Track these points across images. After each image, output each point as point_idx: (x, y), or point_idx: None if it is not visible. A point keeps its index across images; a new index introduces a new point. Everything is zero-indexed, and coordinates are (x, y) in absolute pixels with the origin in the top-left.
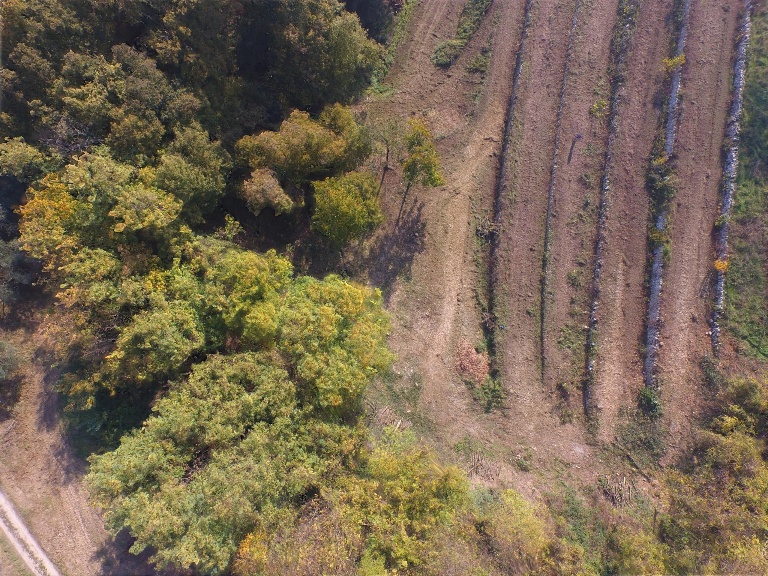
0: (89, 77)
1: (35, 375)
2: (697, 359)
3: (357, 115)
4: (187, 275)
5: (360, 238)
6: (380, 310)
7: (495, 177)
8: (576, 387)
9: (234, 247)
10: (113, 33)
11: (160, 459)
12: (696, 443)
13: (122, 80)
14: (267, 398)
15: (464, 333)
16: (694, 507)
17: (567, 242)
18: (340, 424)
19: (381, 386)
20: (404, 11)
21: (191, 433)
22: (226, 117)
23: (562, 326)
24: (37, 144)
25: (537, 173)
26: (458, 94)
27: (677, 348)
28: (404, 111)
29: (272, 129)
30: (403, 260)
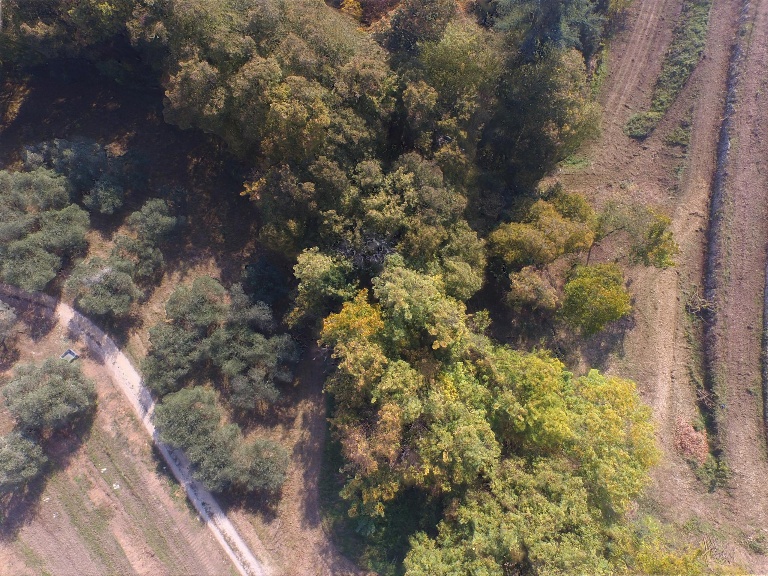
0: (378, 185)
1: (294, 471)
2: None
3: (552, 187)
4: (471, 379)
5: None
6: None
7: (702, 252)
8: None
9: (493, 342)
10: (387, 136)
11: None
12: None
13: (411, 188)
14: (572, 508)
15: (680, 410)
16: None
17: None
18: (618, 524)
19: None
20: (594, 82)
21: (507, 548)
22: (469, 207)
23: None
24: None
25: (751, 251)
26: (657, 167)
27: None
28: (599, 183)
29: (504, 215)
30: (614, 337)
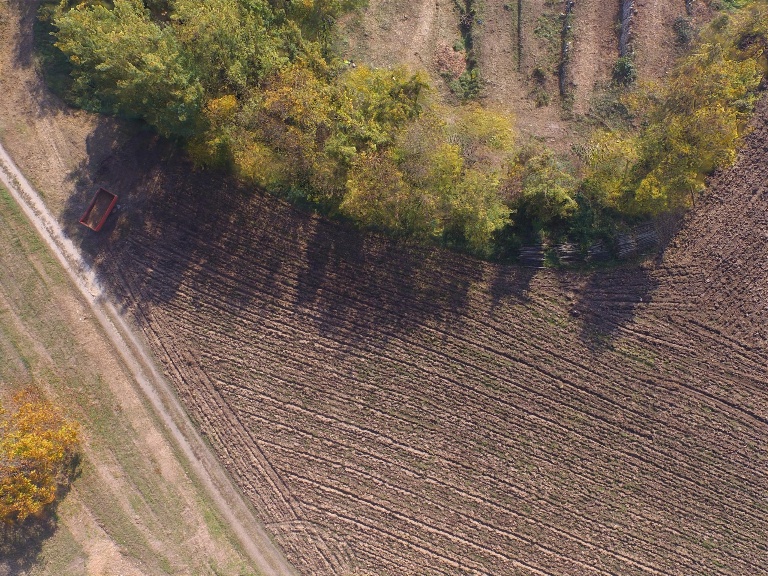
0: None
1: (11, 17)
2: (671, 22)
3: None
4: None
5: None
6: (359, 13)
7: None
8: (552, 73)
9: None
10: None
11: (129, 10)
12: (668, 95)
13: None
14: None
15: (442, 34)
16: (662, 99)
17: None
18: None
19: (359, 80)
20: None
21: None
22: None
23: (539, 16)
24: None
25: None
26: None
27: (651, 15)
28: None
29: None
30: None
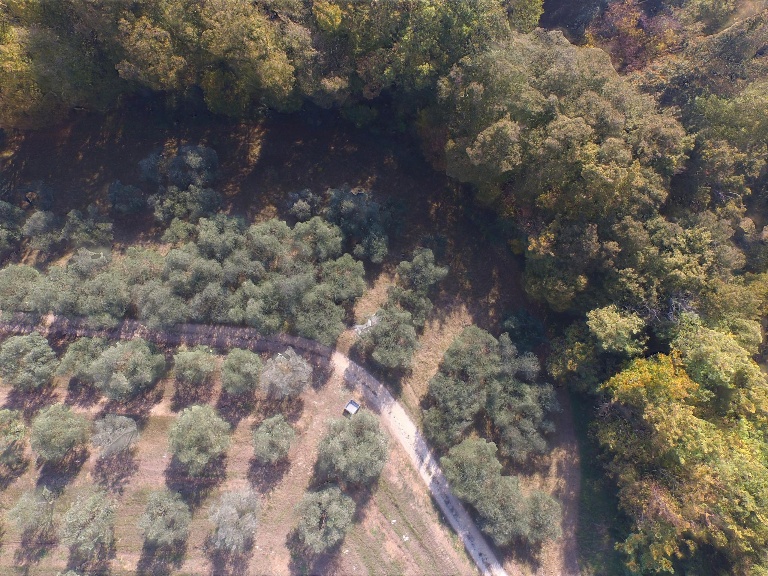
0: None
1: None
2: None
3: (753, 228)
4: (754, 436)
5: None
6: None
7: None
8: None
9: None
10: None
11: None
12: None
13: None
14: None
15: None
16: None
17: None
18: None
19: None
20: None
21: None
22: None
23: None
24: (597, 303)
25: None
26: None
27: None
28: None
29: None
30: None
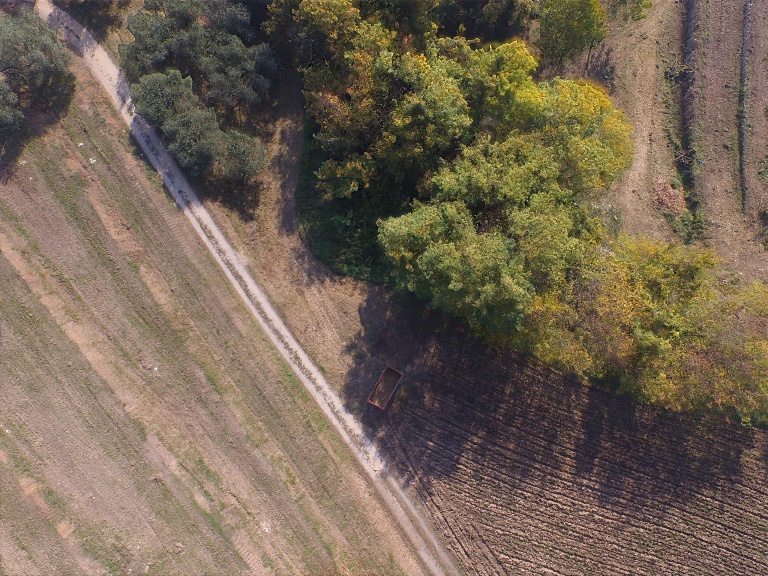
0: None
1: (272, 182)
2: None
3: None
4: None
5: (550, 81)
6: None
7: (682, 22)
8: None
9: None
10: None
11: (457, 215)
12: None
13: None
14: (543, 171)
15: (658, 171)
16: None
17: (764, 77)
18: None
19: None
20: None
21: (477, 198)
22: None
23: (762, 157)
24: None
25: (729, 13)
26: None
27: None
28: None
29: None
30: None
